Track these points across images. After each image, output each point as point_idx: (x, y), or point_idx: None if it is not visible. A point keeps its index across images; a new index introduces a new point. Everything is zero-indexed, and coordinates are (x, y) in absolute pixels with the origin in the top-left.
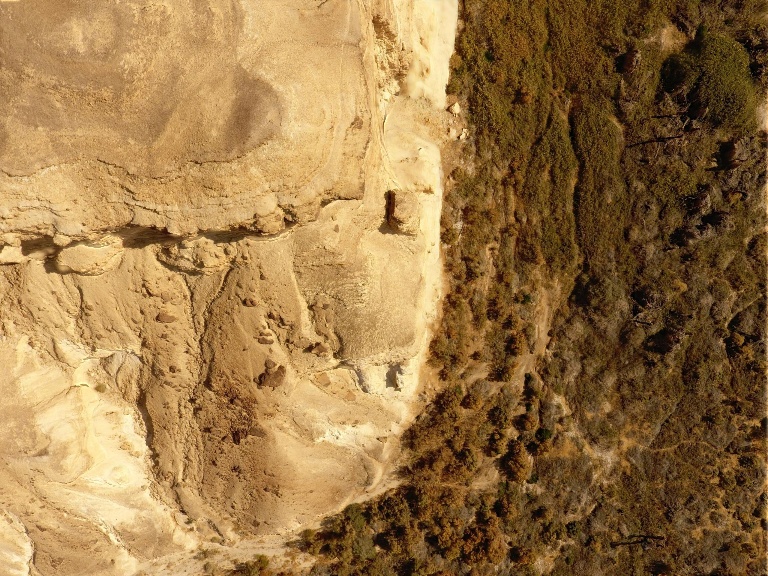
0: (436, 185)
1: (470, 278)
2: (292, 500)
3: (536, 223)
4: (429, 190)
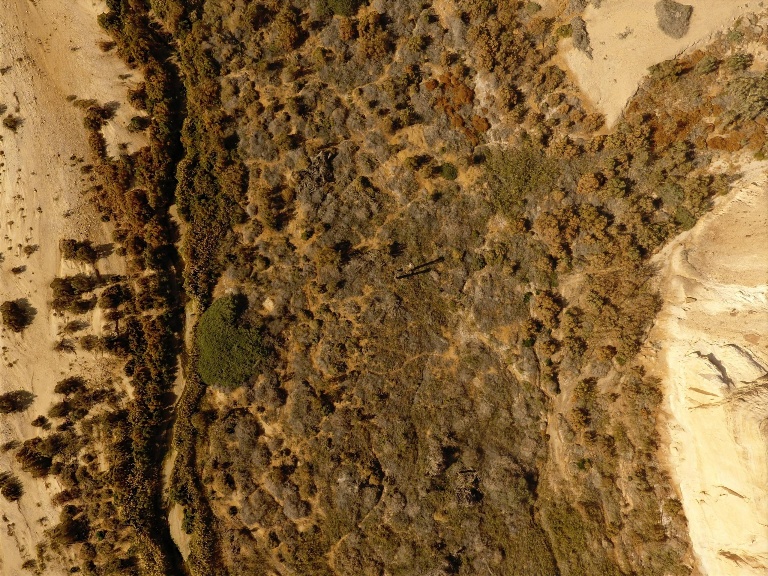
0: (713, 560)
1: (642, 472)
2: (767, 225)
3: (593, 543)
4: (735, 560)
